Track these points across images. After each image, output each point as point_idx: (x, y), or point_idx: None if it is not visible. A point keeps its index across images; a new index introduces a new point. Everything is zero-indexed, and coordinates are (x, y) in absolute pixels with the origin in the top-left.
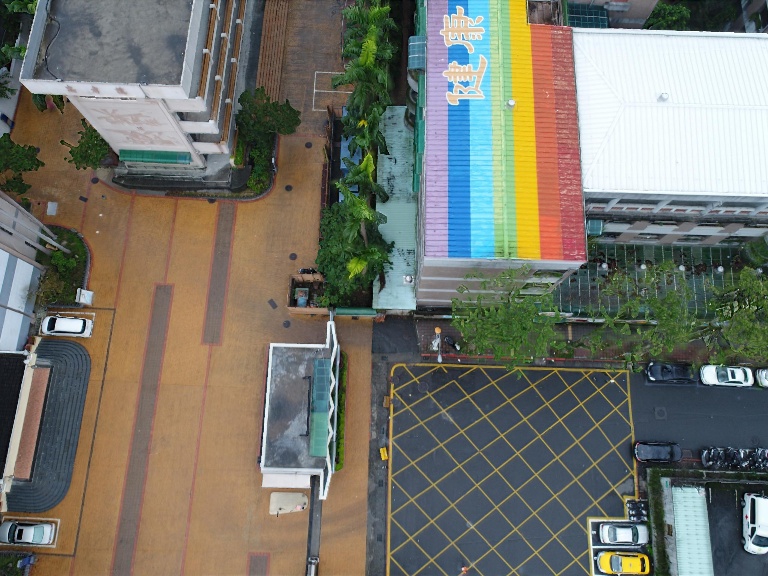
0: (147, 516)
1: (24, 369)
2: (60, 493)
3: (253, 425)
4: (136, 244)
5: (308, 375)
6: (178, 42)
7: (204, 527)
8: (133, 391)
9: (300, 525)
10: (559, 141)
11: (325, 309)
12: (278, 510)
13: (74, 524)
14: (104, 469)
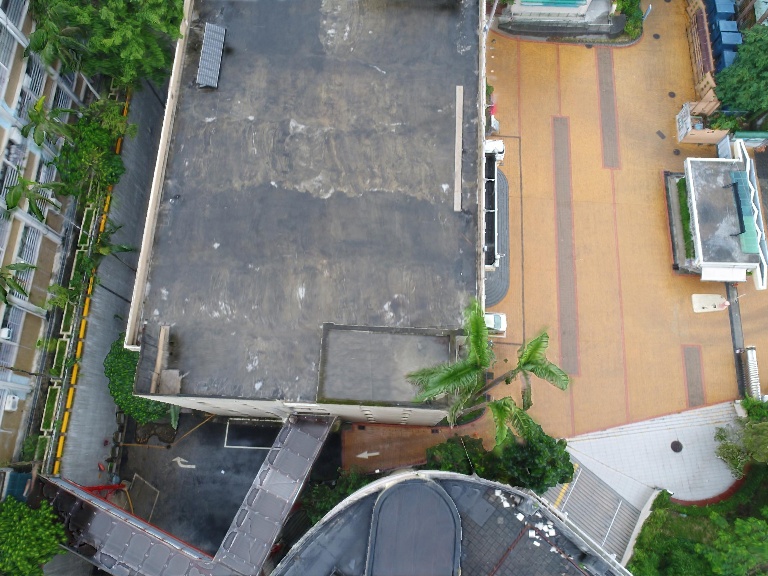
0: (583, 312)
1: (493, 166)
2: (503, 290)
3: (663, 237)
4: (528, 82)
5: None
6: None
7: (637, 322)
8: (550, 207)
9: (723, 323)
10: None
11: (726, 132)
12: (702, 309)
13: (519, 318)
14: (537, 272)
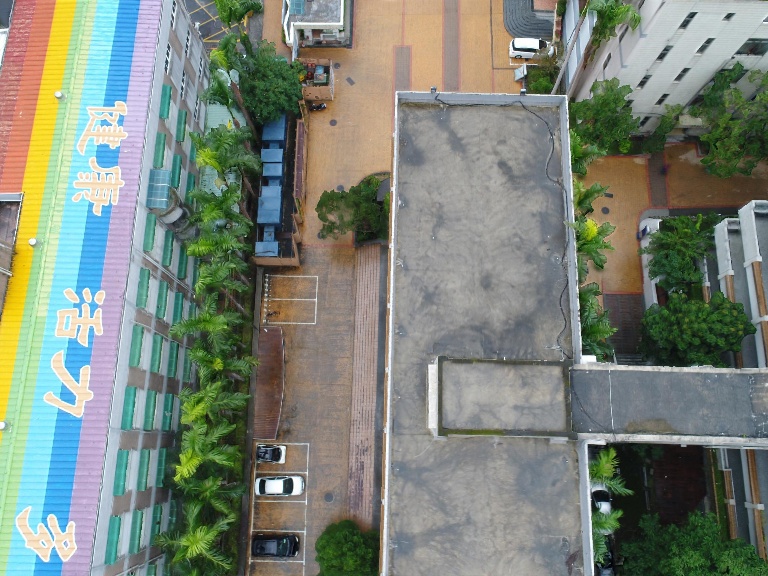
0: None
1: None
2: None
3: None
4: None
5: (309, 3)
6: (412, 157)
7: None
8: (464, 8)
9: None
10: (21, 68)
11: None
12: None
13: None
14: None
